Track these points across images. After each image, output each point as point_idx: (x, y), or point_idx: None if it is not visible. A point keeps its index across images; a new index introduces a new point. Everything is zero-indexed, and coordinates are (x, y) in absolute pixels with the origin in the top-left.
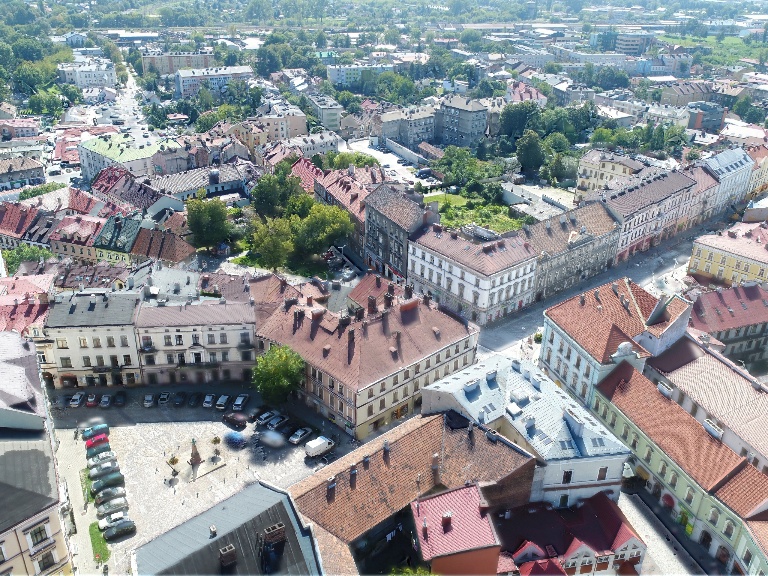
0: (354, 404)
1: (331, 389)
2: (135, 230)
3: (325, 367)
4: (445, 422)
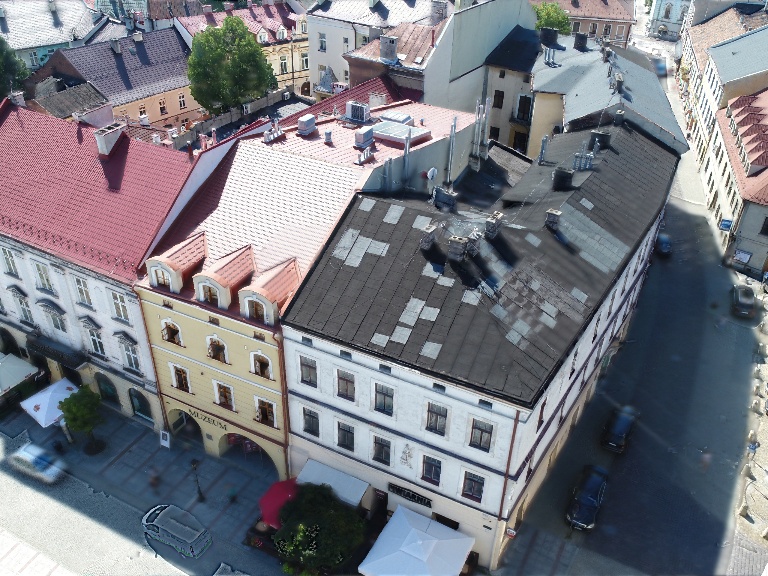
0: (625, 38)
1: (592, 35)
2: (142, 2)
3: (585, 14)
4: (739, 13)
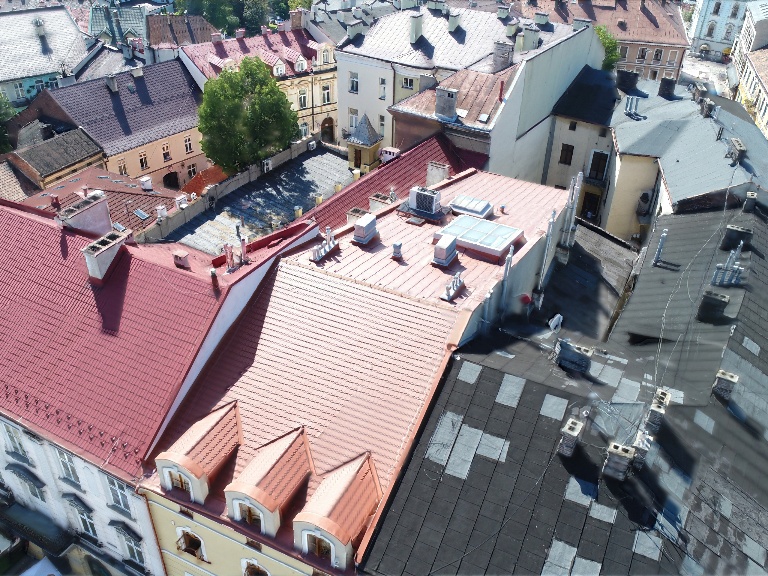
0: (678, 64)
1: (641, 61)
2: (141, 19)
3: (634, 37)
4: None
